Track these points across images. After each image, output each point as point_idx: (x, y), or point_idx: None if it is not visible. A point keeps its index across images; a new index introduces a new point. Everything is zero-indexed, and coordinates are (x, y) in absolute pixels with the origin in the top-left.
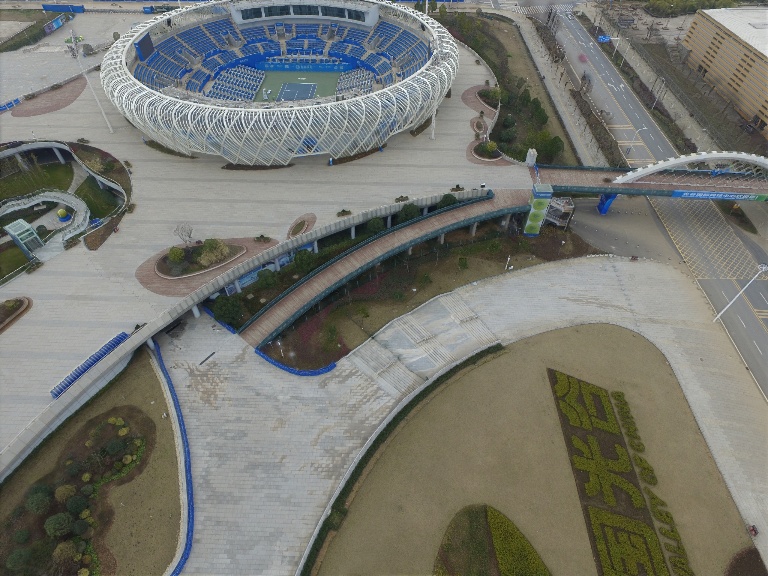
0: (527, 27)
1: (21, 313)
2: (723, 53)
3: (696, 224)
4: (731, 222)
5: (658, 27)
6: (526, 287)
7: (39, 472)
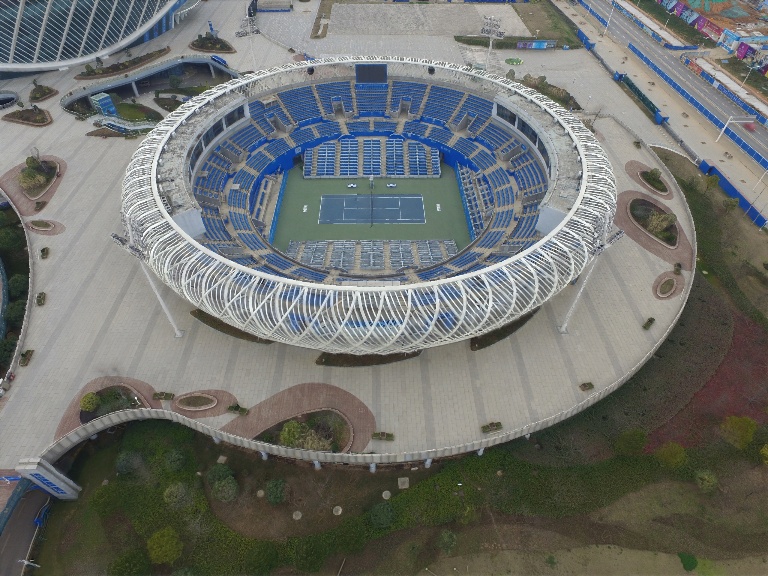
0: None
1: (35, 125)
2: None
3: None
4: None
5: None
6: None
7: None
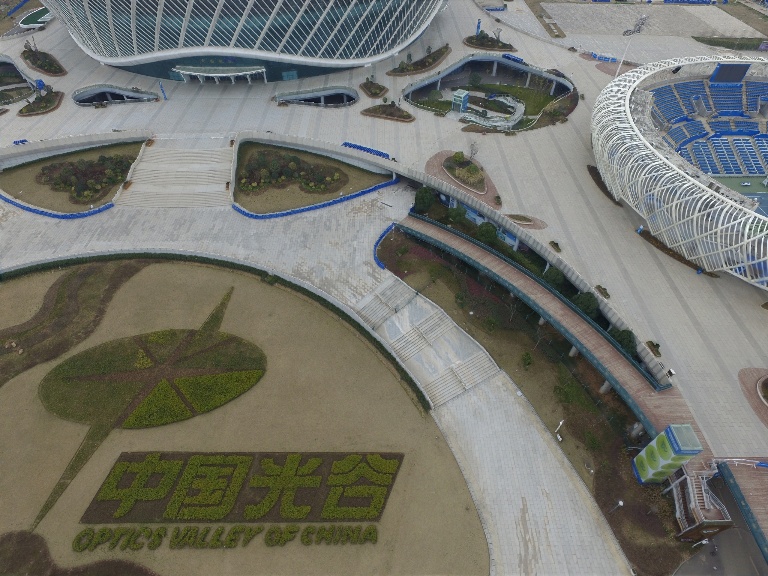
0: None
1: (402, 121)
2: None
3: None
4: None
5: None
6: (531, 455)
7: (309, 160)
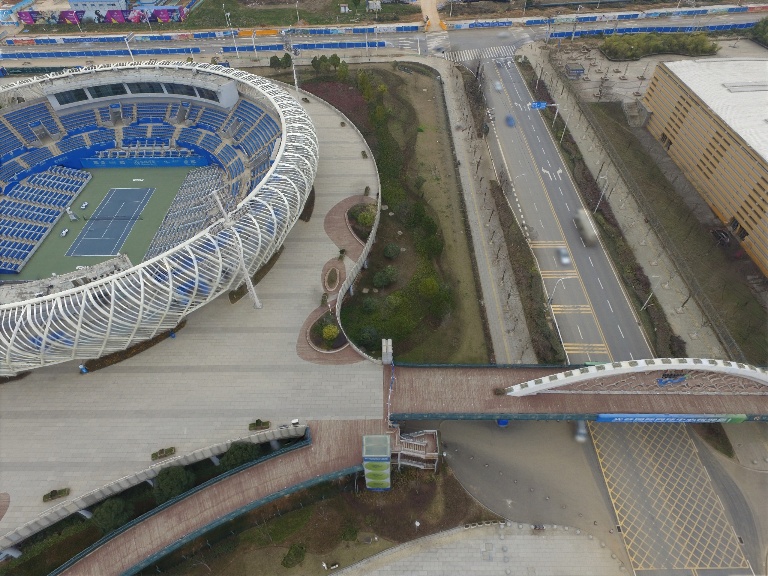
0: (453, 82)
1: None
2: (690, 124)
3: (642, 439)
4: (694, 432)
5: (614, 76)
6: None
7: None
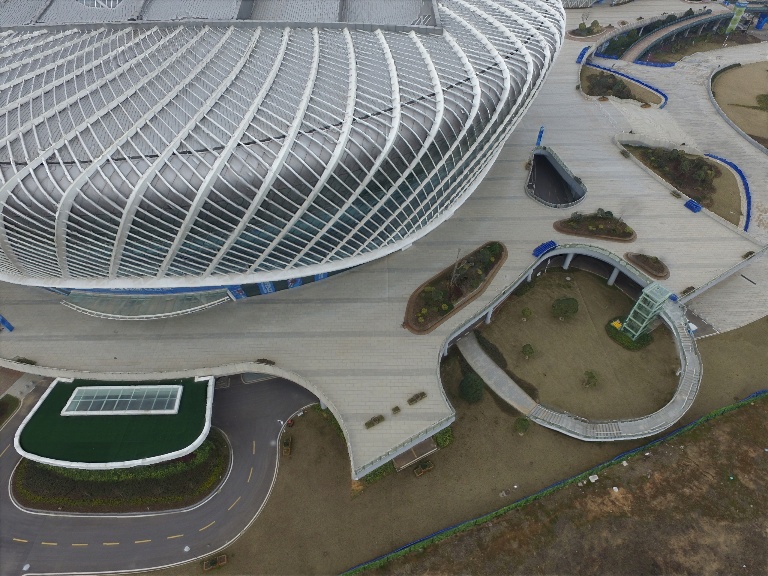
0: None
1: None
2: None
3: None
4: None
5: None
6: (737, 52)
7: (586, 84)
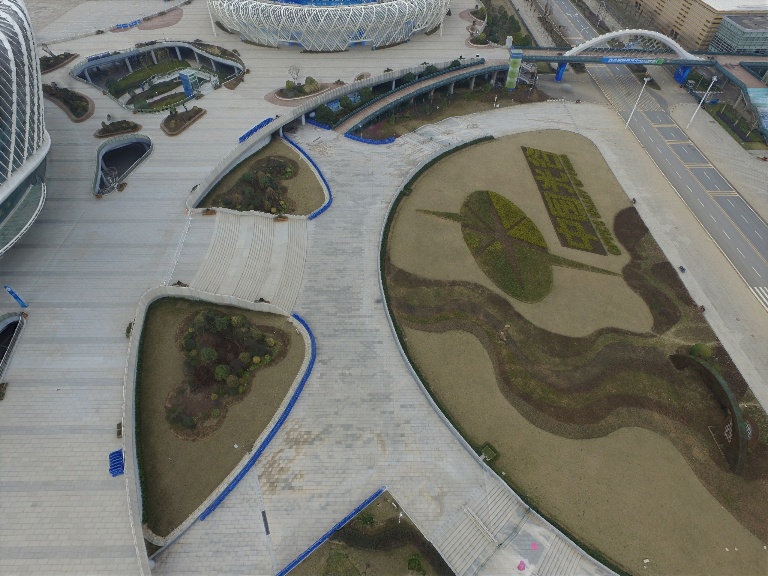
0: None
1: (203, 114)
2: None
3: (621, 86)
4: None
5: None
6: (508, 115)
7: (240, 175)
